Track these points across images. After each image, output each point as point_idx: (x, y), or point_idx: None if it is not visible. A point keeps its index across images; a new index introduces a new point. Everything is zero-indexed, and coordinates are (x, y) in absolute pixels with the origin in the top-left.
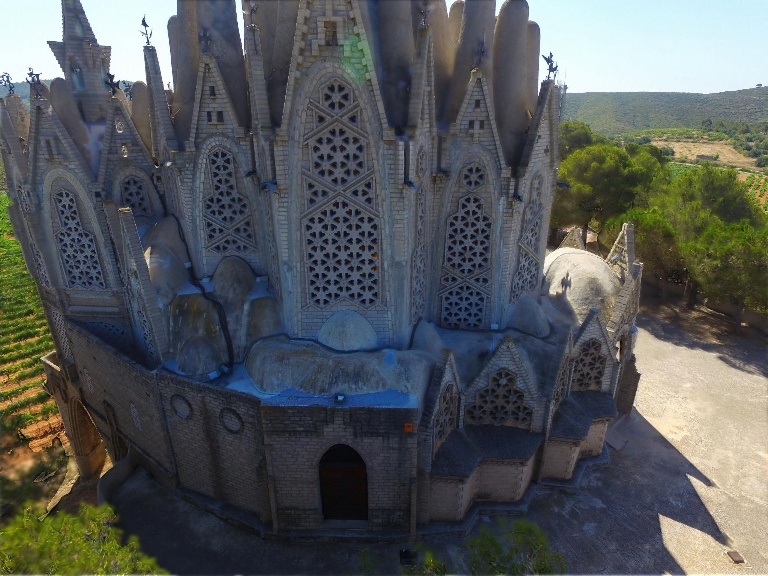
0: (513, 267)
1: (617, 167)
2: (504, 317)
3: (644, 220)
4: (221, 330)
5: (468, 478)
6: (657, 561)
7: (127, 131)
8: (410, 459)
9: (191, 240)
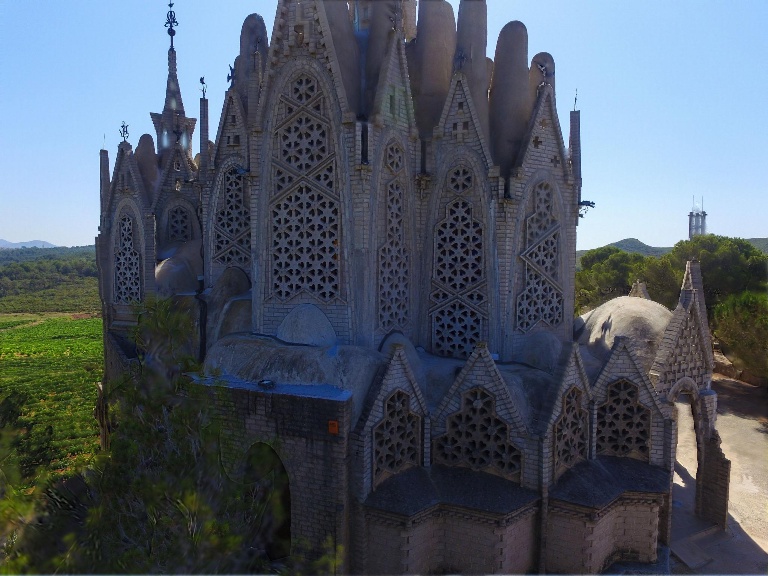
0: (516, 285)
1: (736, 255)
2: (507, 346)
3: (765, 301)
4: (199, 326)
5: (415, 524)
6: None
7: (183, 170)
8: (336, 475)
9: (204, 252)
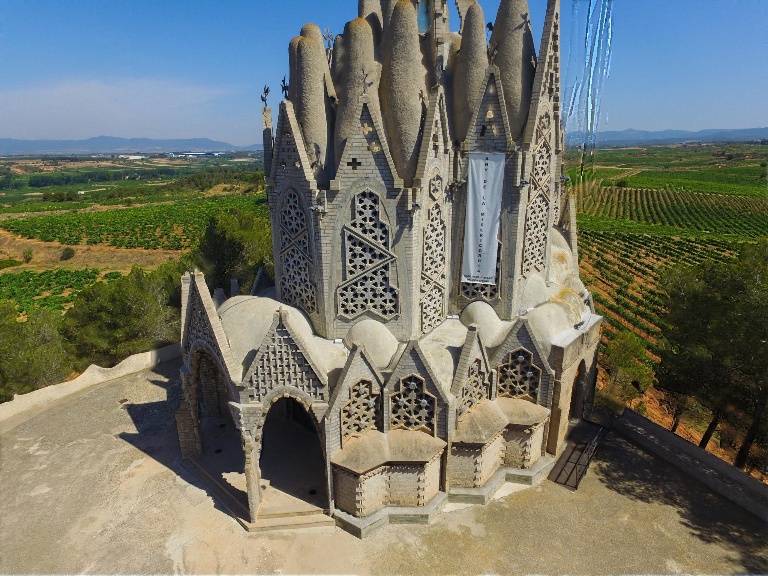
0: None
1: None
2: None
3: None
4: None
5: None
6: (171, 382)
7: None
8: None
9: None
